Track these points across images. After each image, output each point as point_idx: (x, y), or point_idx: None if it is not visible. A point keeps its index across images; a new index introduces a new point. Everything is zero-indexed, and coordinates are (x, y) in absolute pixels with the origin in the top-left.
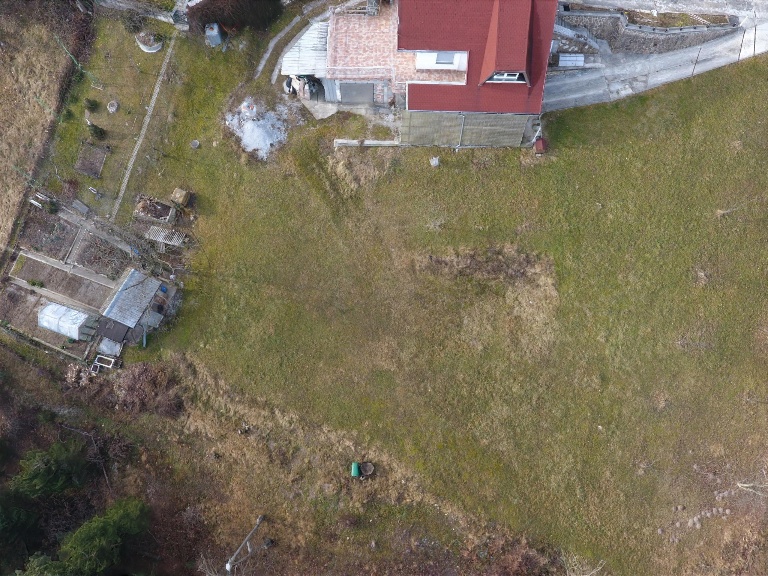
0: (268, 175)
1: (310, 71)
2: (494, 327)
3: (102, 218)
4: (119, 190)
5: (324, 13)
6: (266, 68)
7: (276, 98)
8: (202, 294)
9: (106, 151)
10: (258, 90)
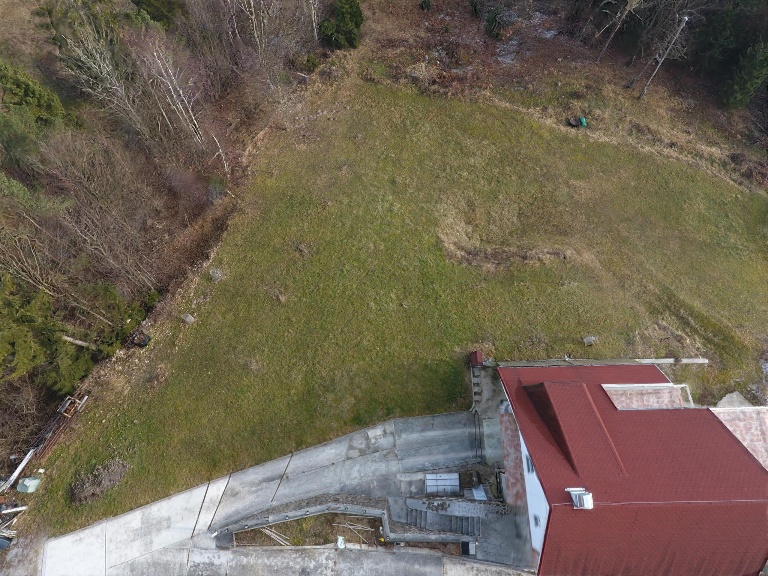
0: (761, 329)
1: None
2: (489, 215)
3: None
4: None
5: None
6: None
7: None
8: (760, 237)
9: None
10: None
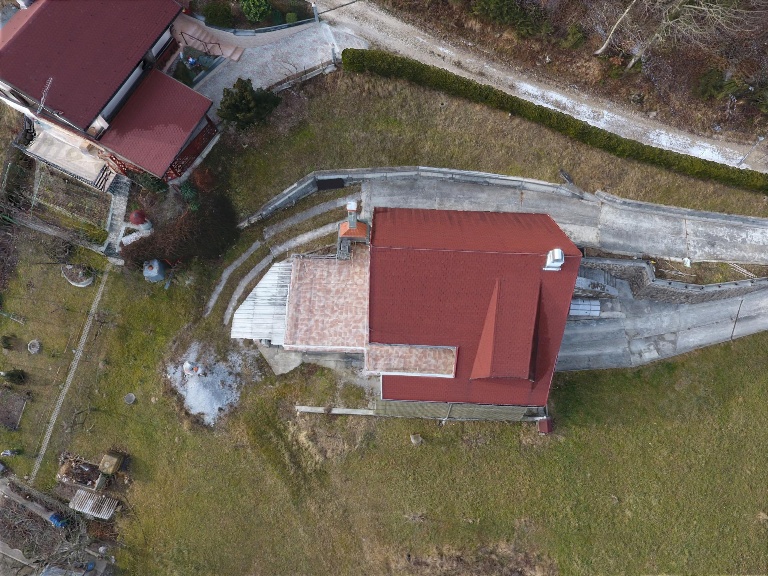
0: (216, 443)
1: (266, 335)
2: None
3: (19, 479)
4: (40, 446)
5: (288, 242)
6: (218, 305)
7: (229, 344)
8: None
9: (26, 398)
10: (207, 333)
